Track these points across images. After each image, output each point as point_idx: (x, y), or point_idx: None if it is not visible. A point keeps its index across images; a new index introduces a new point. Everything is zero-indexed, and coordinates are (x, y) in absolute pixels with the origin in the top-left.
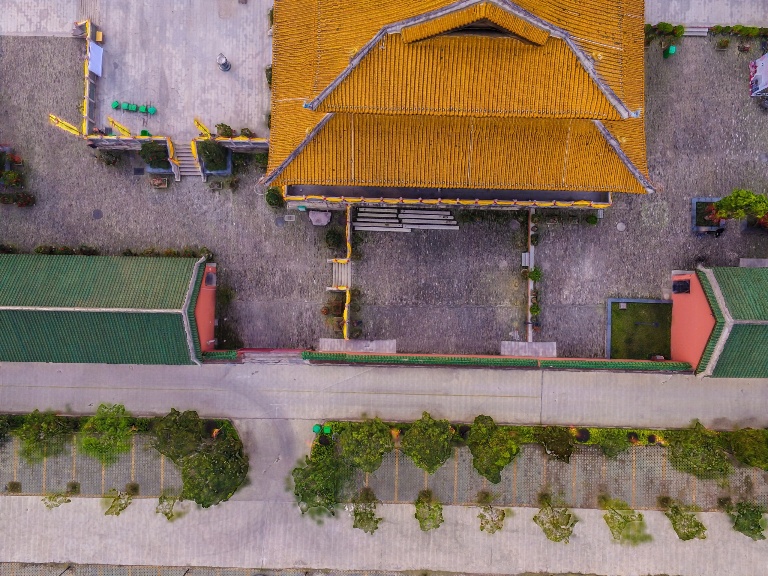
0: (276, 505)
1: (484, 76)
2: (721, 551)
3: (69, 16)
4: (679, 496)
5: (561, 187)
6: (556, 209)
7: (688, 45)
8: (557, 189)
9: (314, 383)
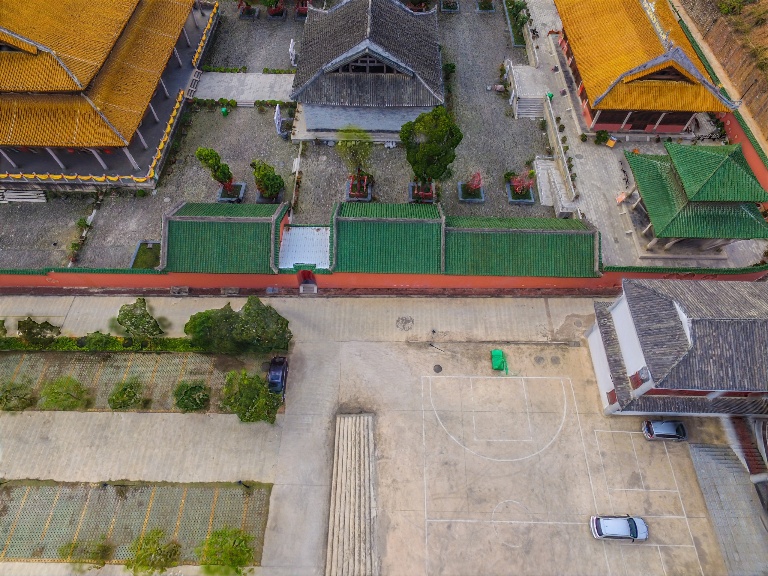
0: None
1: (3, 71)
2: (190, 453)
3: None
4: (161, 398)
5: (72, 144)
6: (121, 189)
7: (242, 111)
8: (69, 145)
9: None
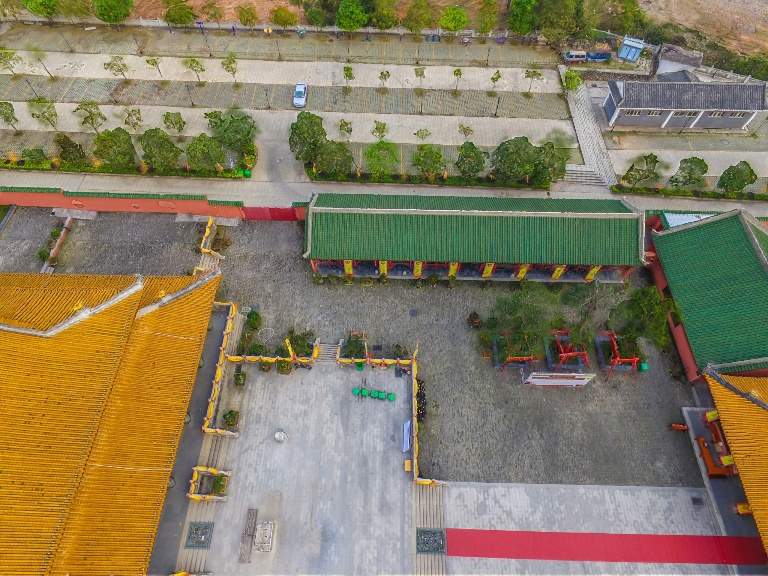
0: (285, 138)
1: None
2: None
3: (454, 507)
4: (7, 136)
5: None
6: None
7: None
8: None
9: (247, 201)
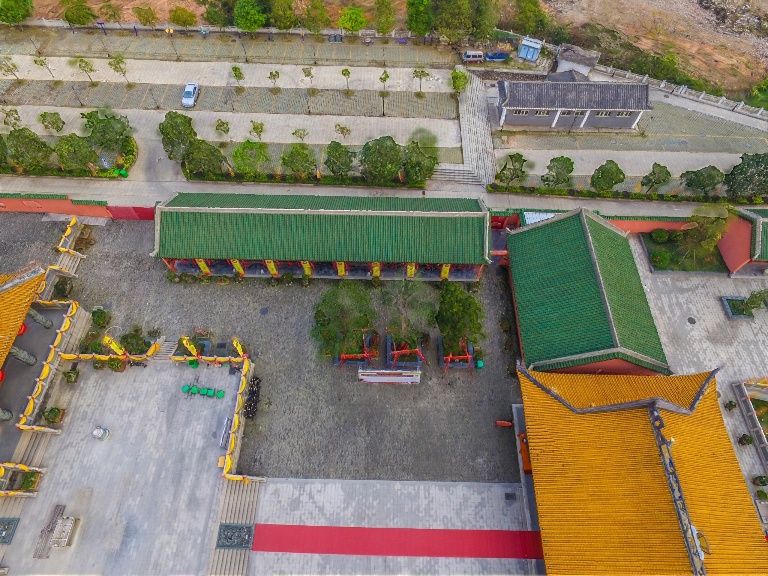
0: None
1: None
2: None
3: (268, 503)
4: None
5: None
6: None
7: None
8: None
9: (120, 200)
